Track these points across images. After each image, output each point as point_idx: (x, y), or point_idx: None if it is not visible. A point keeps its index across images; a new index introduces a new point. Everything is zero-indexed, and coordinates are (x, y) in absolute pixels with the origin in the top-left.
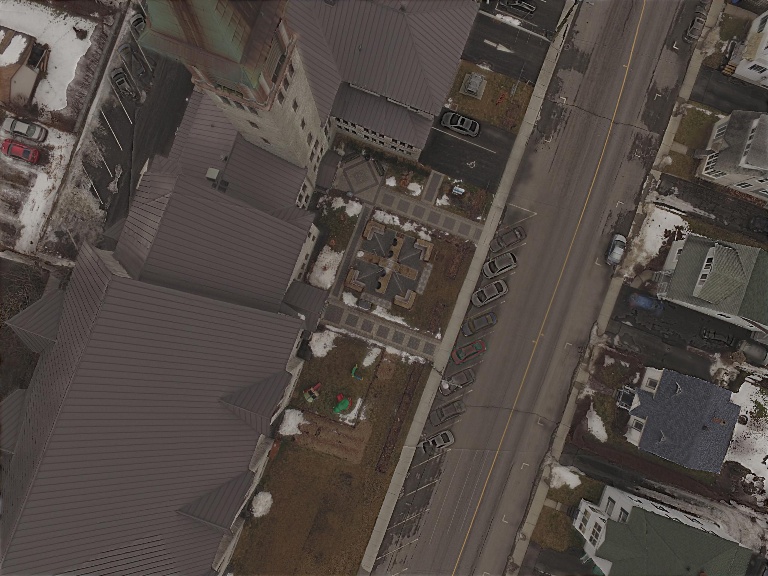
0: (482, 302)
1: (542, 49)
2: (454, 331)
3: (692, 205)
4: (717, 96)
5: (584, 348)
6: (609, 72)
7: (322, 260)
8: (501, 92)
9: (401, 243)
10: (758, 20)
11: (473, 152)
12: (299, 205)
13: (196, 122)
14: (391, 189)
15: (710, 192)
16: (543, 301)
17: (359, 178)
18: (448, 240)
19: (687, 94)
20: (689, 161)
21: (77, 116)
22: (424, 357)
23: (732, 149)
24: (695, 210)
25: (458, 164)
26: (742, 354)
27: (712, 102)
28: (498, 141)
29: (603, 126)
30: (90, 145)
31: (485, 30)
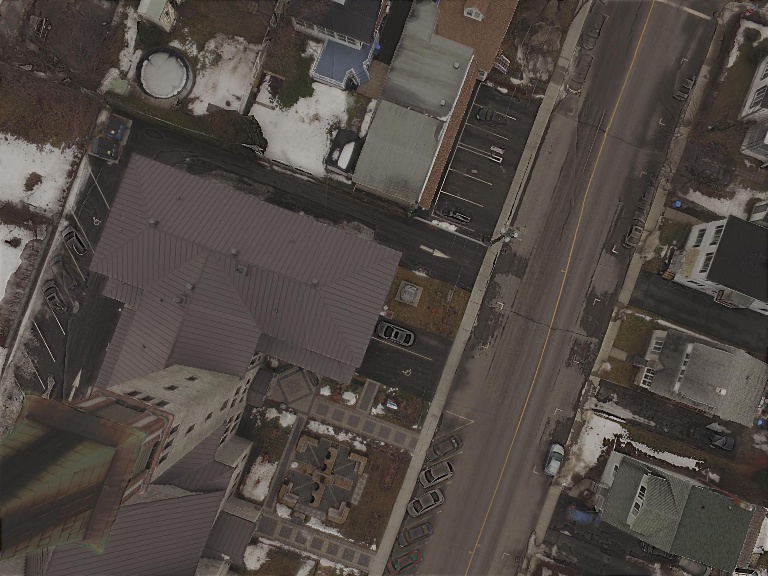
0: (418, 512)
1: (479, 254)
2: (389, 542)
3: (631, 412)
4: (657, 301)
5: (522, 558)
6: (547, 277)
7: (255, 472)
8: (437, 299)
9: (335, 456)
10: (696, 229)
11: (409, 360)
12: (226, 434)
13: (113, 379)
14: (326, 398)
15: (650, 399)
16: (480, 511)
17: (293, 388)
18: (383, 450)
19: (626, 299)
20: (628, 368)
21: (8, 333)
22: (359, 569)
23: (667, 371)
24: (634, 417)
25: (394, 372)
26: (680, 572)
27: (652, 307)
28: (434, 348)
29: (541, 332)
30: (22, 357)
31: (421, 236)
